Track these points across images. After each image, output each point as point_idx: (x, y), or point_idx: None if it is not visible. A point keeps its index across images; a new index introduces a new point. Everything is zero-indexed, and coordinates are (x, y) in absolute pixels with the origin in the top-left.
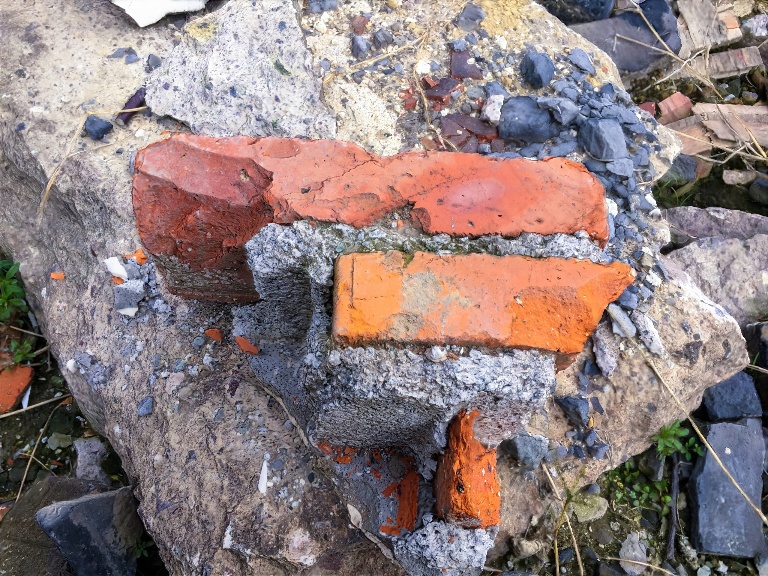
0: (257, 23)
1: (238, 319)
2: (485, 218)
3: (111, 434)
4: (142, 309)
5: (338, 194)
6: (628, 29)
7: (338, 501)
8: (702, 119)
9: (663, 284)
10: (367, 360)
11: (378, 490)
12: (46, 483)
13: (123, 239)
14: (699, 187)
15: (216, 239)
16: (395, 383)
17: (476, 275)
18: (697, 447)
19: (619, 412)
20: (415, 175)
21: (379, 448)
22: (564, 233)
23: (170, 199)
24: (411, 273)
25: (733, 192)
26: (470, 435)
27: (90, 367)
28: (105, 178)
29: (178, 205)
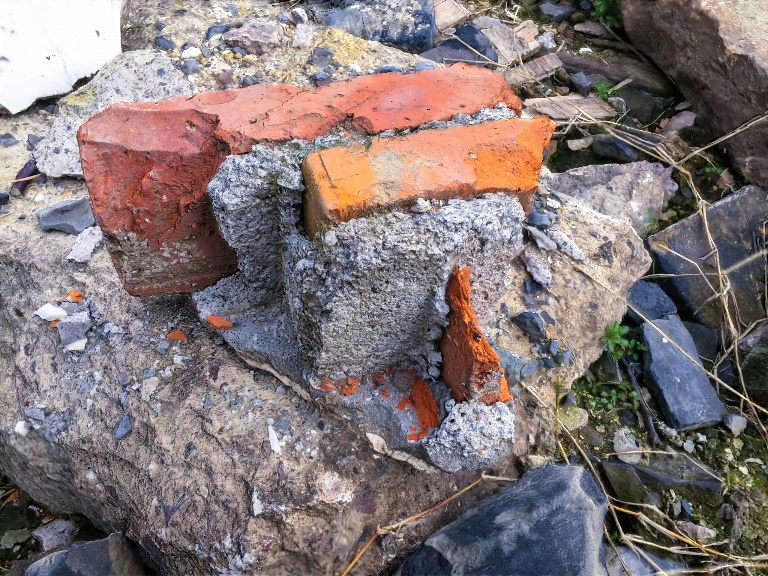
0: (135, 77)
1: (202, 302)
2: (417, 113)
3: (84, 485)
4: (91, 340)
5: (284, 119)
6: (451, 53)
7: (355, 438)
8: (535, 107)
9: (562, 207)
10: (362, 229)
11: (392, 407)
12: (17, 569)
13: (49, 289)
14: (552, 162)
15: (172, 202)
16: (393, 240)
17: (430, 145)
18: (639, 345)
19: (568, 318)
20: (345, 94)
21: (379, 371)
22: (487, 107)
23: (121, 165)
24: (374, 154)
25: (581, 156)
26: (469, 288)
27: (45, 419)
28: (14, 240)
29: (130, 170)
